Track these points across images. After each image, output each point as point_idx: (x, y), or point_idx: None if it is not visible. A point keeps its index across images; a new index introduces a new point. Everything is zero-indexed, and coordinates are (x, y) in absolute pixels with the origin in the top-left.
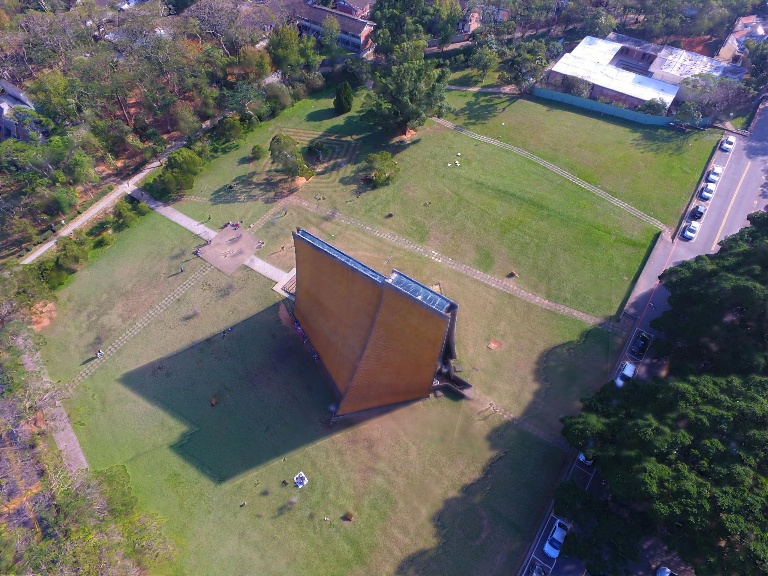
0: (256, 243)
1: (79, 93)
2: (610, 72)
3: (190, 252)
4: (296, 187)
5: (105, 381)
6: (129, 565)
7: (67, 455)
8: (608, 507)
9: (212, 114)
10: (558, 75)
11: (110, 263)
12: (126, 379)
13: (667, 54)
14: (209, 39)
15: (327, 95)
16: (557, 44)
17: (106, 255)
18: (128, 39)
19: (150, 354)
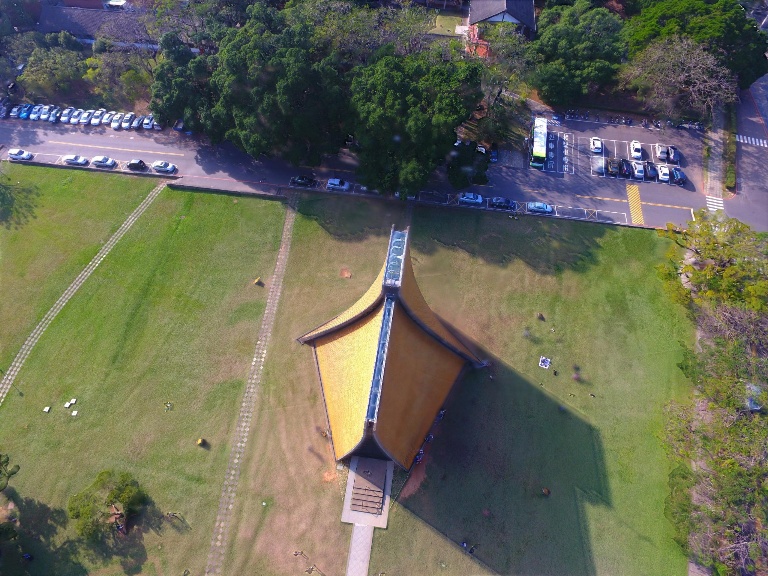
0: None
1: None
2: None
3: None
4: None
5: None
6: (707, 416)
7: None
8: (451, 163)
9: None
10: None
11: None
12: None
13: None
14: None
15: None
16: None
17: None
18: None
19: None
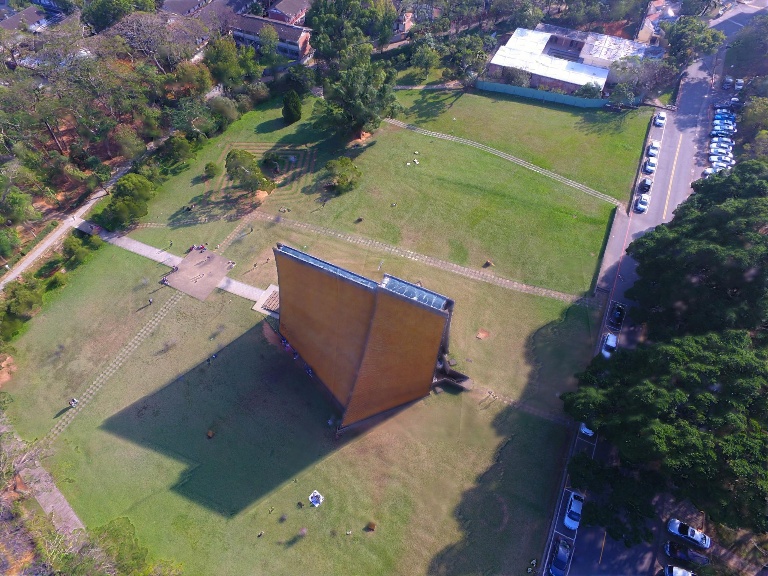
0: (226, 264)
1: (5, 126)
2: (544, 61)
3: (156, 282)
4: (258, 202)
5: (85, 431)
6: None
7: (56, 517)
8: (619, 472)
9: (156, 135)
10: (498, 67)
11: (68, 304)
12: (109, 425)
13: (593, 40)
14: (141, 57)
15: (273, 105)
16: (491, 38)
17: (62, 296)
18: (51, 63)
19: (131, 395)
